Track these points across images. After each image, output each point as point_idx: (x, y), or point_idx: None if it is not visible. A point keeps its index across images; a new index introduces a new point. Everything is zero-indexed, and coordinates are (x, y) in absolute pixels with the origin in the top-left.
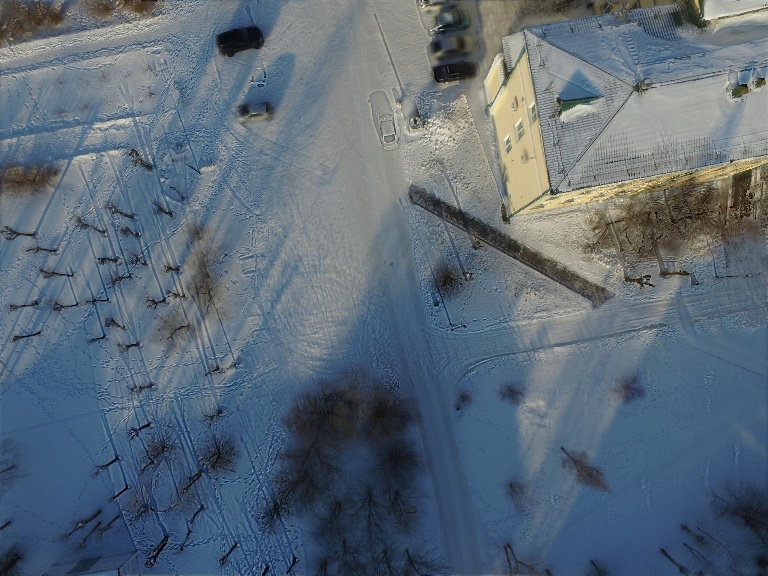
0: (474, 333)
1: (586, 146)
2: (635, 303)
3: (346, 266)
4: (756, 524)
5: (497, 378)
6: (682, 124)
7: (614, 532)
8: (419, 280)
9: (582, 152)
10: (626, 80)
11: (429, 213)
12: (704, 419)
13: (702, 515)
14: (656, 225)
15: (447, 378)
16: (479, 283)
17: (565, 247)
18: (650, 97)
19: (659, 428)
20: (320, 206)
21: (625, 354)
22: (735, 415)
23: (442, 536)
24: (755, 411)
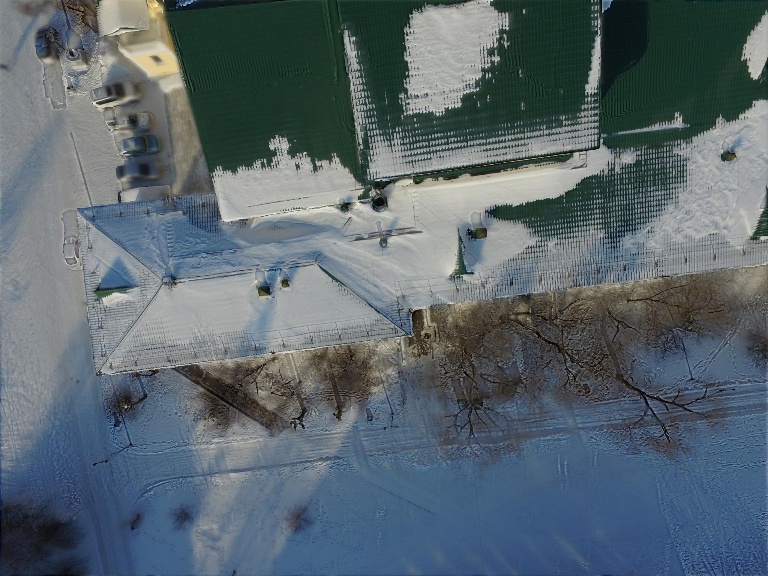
0: (154, 454)
1: (124, 333)
2: (312, 434)
3: (33, 381)
4: None
5: (173, 500)
6: (216, 317)
7: None
8: (103, 399)
9: (121, 338)
10: (157, 273)
11: None
12: (374, 552)
13: None
14: (333, 359)
15: (127, 496)
16: (160, 406)
17: (245, 375)
18: (180, 291)
19: (329, 559)
20: (10, 321)
21: (300, 484)
22: (404, 550)
23: None
24: (424, 548)
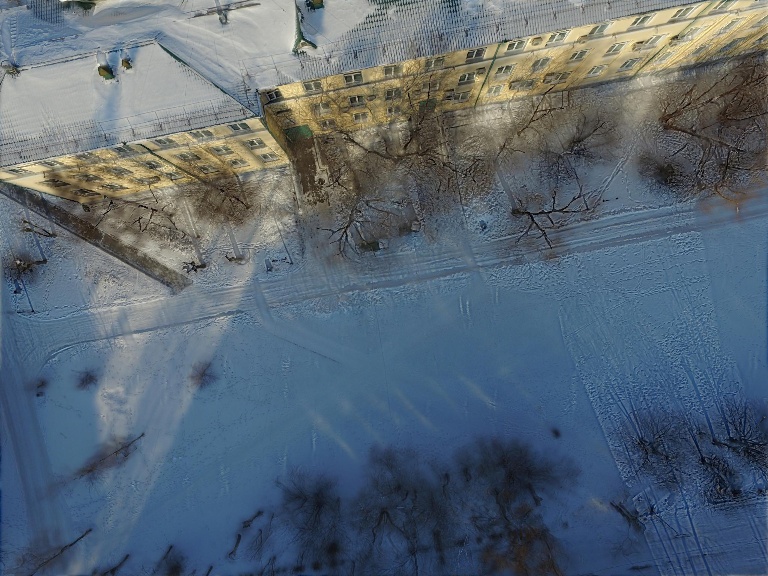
0: (57, 320)
1: None
2: (213, 290)
3: None
4: (308, 510)
5: (78, 365)
6: (63, 106)
7: (193, 518)
8: (3, 268)
9: None
10: None
11: (12, 201)
12: (281, 405)
13: (275, 501)
14: (230, 212)
15: (32, 365)
16: (60, 270)
17: (143, 234)
18: (24, 79)
19: (237, 414)
20: None
21: (203, 341)
22: (311, 402)
23: (29, 521)
24: (331, 398)
